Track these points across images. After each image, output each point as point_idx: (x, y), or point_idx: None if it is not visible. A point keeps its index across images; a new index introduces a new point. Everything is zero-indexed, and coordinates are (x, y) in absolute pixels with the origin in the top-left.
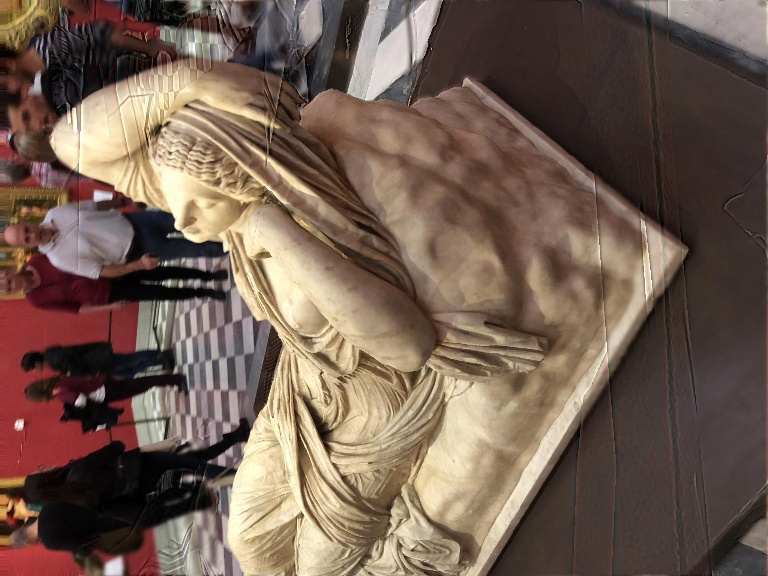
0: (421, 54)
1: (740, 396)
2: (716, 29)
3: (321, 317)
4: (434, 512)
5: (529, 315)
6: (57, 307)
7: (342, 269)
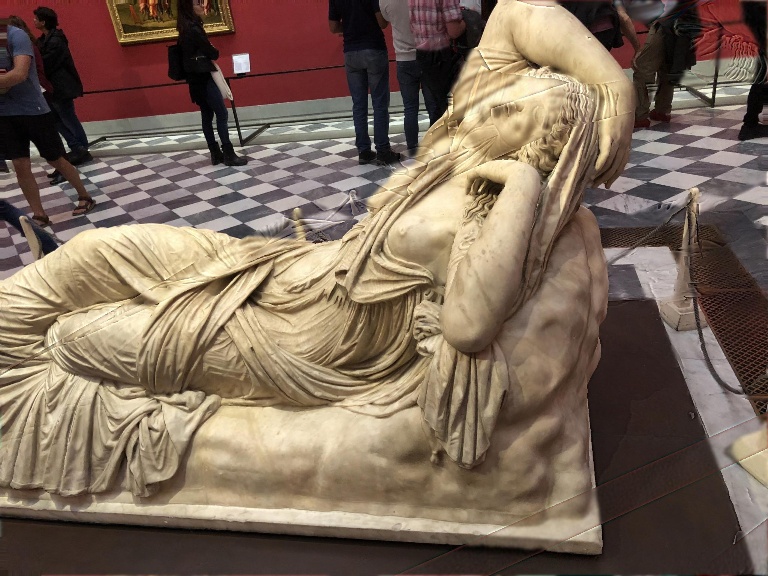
0: None
1: None
2: (734, 507)
3: (417, 252)
4: (206, 435)
5: (505, 434)
6: None
7: None
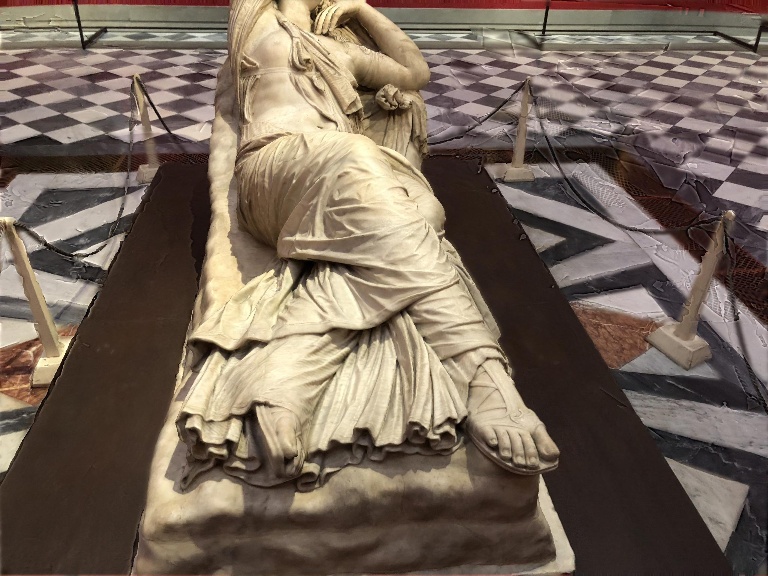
0: (96, 225)
1: (474, 196)
2: None
3: None
4: None
5: None
6: None
7: None
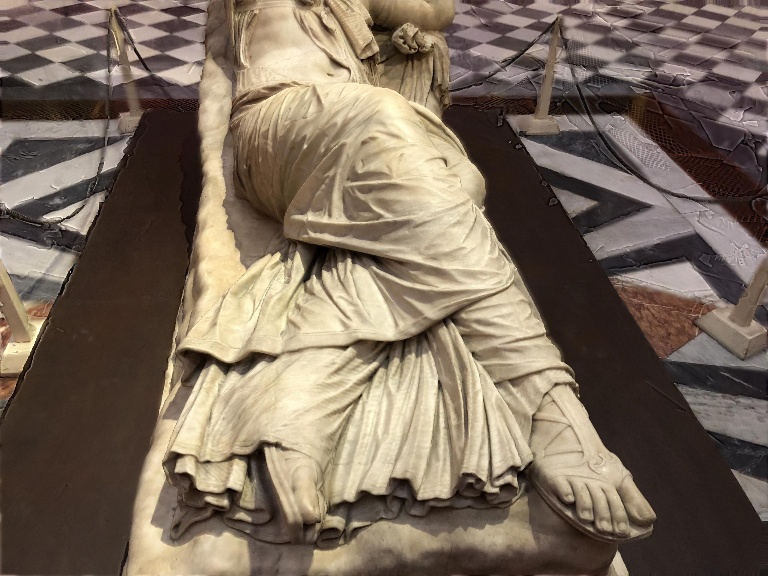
0: (73, 181)
1: (497, 153)
2: None
3: None
4: None
5: None
6: None
7: None
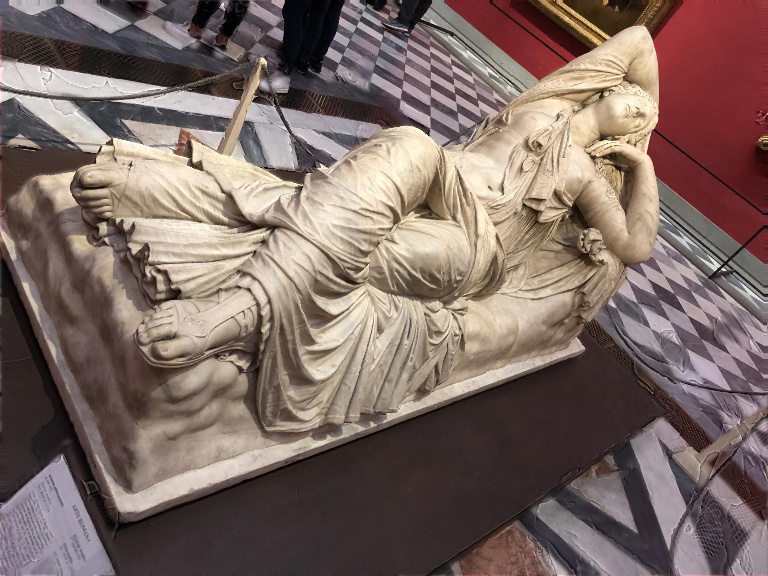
0: None
1: (603, 410)
2: None
3: None
4: (468, 331)
5: None
6: None
7: None
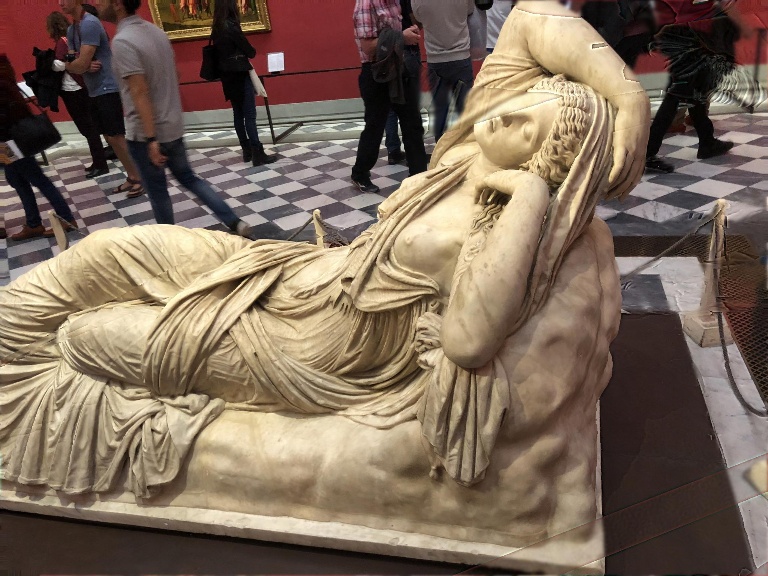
0: None
1: None
2: (750, 536)
3: (423, 262)
4: (207, 439)
5: (506, 452)
6: (565, 3)
7: (530, 261)
